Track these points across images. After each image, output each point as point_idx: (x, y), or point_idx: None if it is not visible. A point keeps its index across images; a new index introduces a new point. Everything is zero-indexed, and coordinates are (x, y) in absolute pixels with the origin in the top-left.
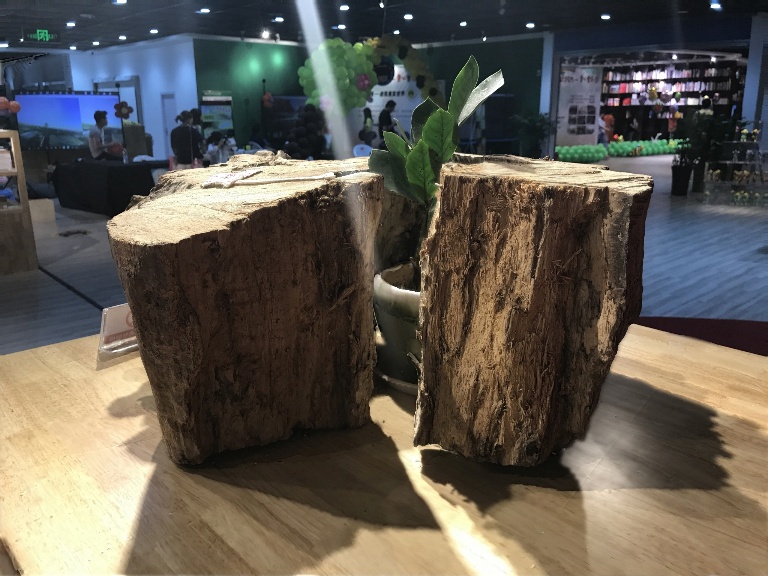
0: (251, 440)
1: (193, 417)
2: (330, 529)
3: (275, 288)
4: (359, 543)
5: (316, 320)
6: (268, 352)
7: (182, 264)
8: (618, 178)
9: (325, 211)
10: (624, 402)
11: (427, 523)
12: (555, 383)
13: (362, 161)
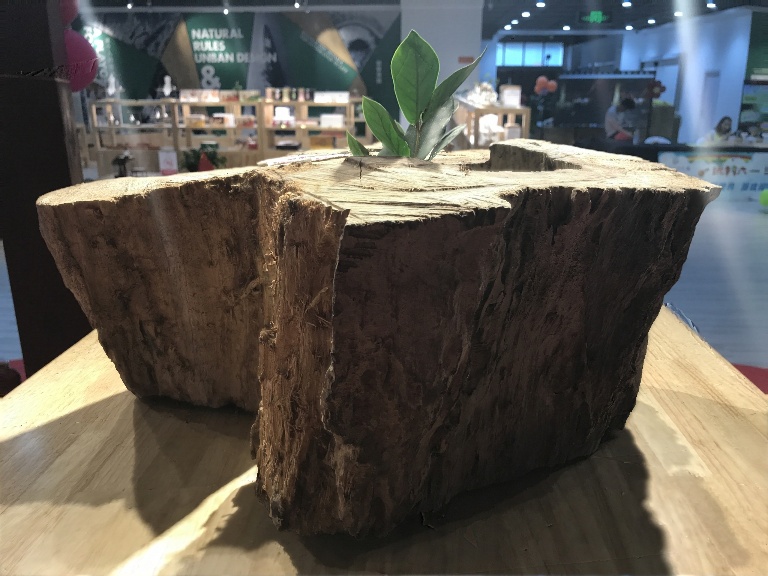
0: (185, 396)
1: (114, 355)
2: (110, 487)
3: (188, 264)
4: (100, 508)
5: (235, 304)
6: (189, 321)
7: (66, 224)
8: (408, 201)
9: (236, 198)
10: (578, 542)
11: (157, 525)
12: (313, 446)
13: (461, 154)
